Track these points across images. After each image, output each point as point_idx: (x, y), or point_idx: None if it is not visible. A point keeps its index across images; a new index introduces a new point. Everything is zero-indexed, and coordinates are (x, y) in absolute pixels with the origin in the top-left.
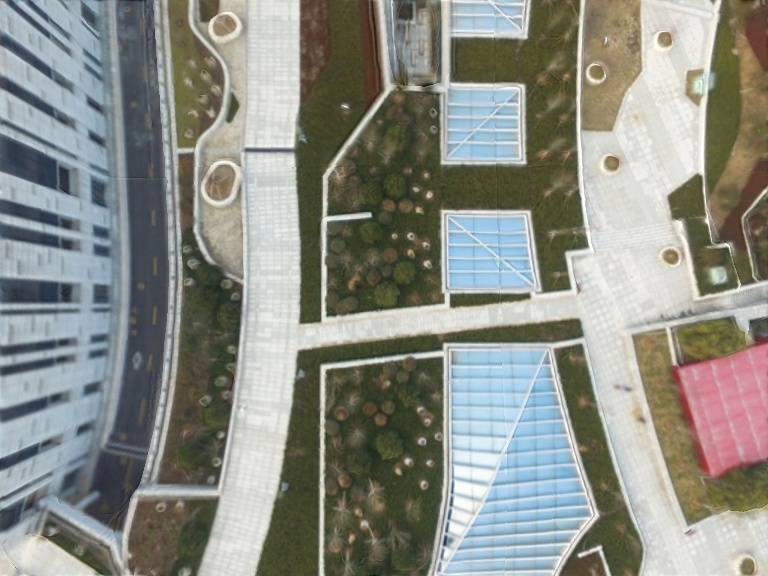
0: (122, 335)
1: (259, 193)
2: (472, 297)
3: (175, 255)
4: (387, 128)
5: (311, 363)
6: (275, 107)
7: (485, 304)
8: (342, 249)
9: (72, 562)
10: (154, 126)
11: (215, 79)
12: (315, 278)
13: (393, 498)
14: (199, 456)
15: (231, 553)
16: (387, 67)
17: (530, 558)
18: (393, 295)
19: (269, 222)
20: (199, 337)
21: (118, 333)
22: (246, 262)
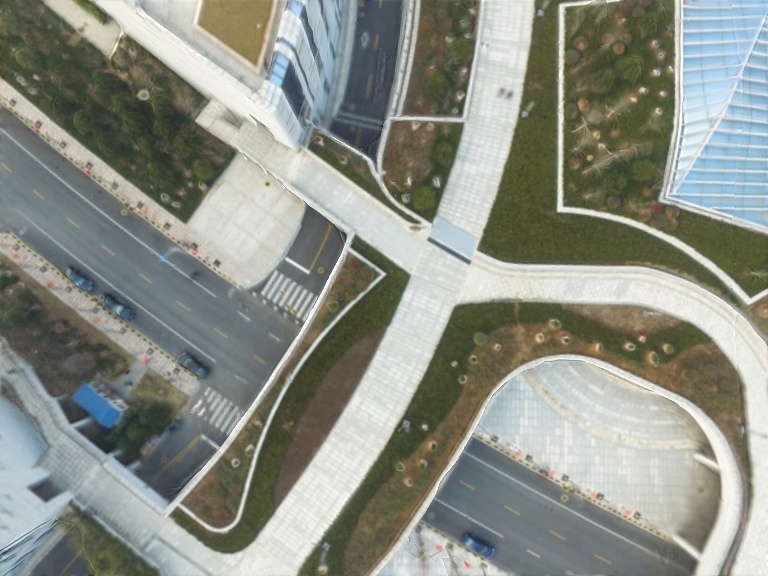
0: (352, 17)
1: None
2: None
3: None
4: None
5: (549, 5)
6: None
7: None
8: None
9: (333, 175)
10: None
11: None
12: None
13: (629, 122)
14: (449, 82)
15: (474, 174)
16: None
17: (759, 183)
18: None
19: None
20: None
21: (348, 14)
22: None
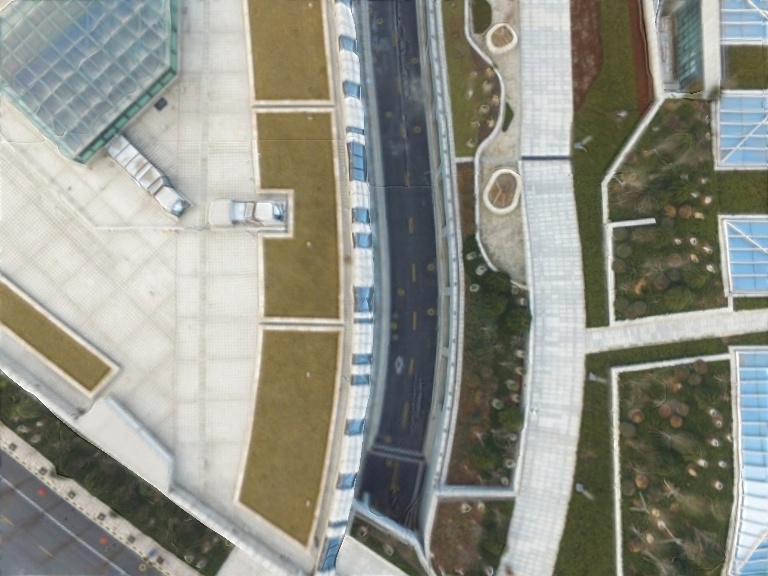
0: (384, 340)
1: (537, 200)
2: (754, 301)
3: (456, 262)
4: (666, 135)
5: (600, 366)
6: (549, 116)
7: (766, 307)
8: (629, 255)
9: (378, 561)
10: (409, 135)
11: (493, 89)
12: (601, 283)
13: (689, 498)
14: (499, 458)
15: (528, 553)
16: (660, 75)
17: None
18: (688, 299)
19: (549, 229)
20: (487, 342)
21: (381, 338)
22: (531, 268)
